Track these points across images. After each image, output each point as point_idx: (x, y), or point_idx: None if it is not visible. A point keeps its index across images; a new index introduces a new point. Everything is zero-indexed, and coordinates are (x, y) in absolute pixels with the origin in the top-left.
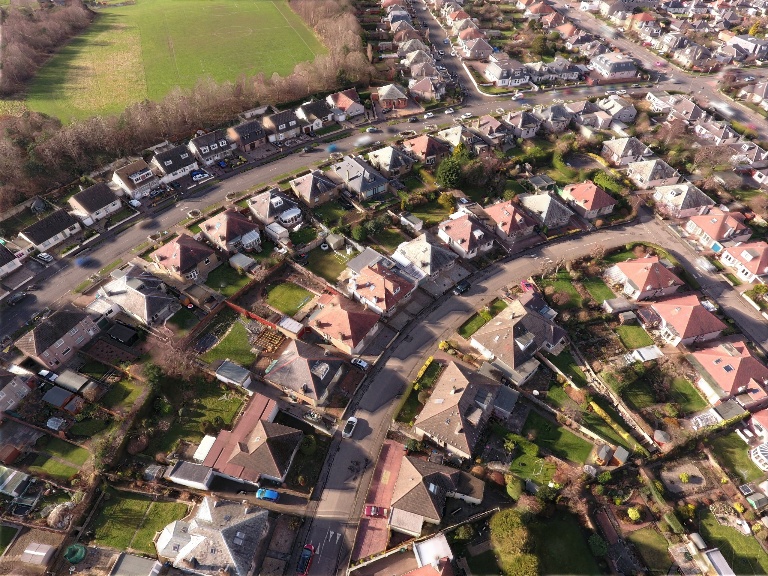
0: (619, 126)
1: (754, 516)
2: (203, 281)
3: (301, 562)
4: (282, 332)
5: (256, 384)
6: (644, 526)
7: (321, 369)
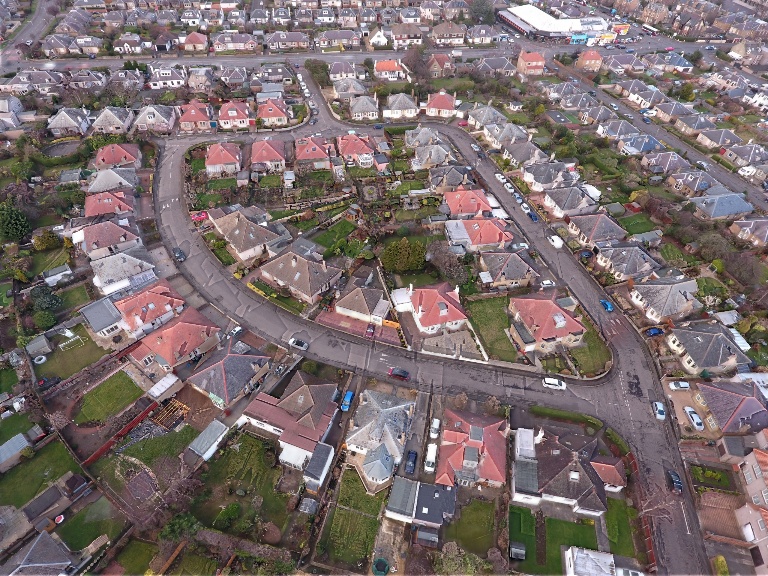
0: (29, 115)
1: (394, 176)
2: (12, 510)
3: (401, 374)
4: (166, 399)
5: (226, 423)
6: (393, 214)
7: (242, 346)
